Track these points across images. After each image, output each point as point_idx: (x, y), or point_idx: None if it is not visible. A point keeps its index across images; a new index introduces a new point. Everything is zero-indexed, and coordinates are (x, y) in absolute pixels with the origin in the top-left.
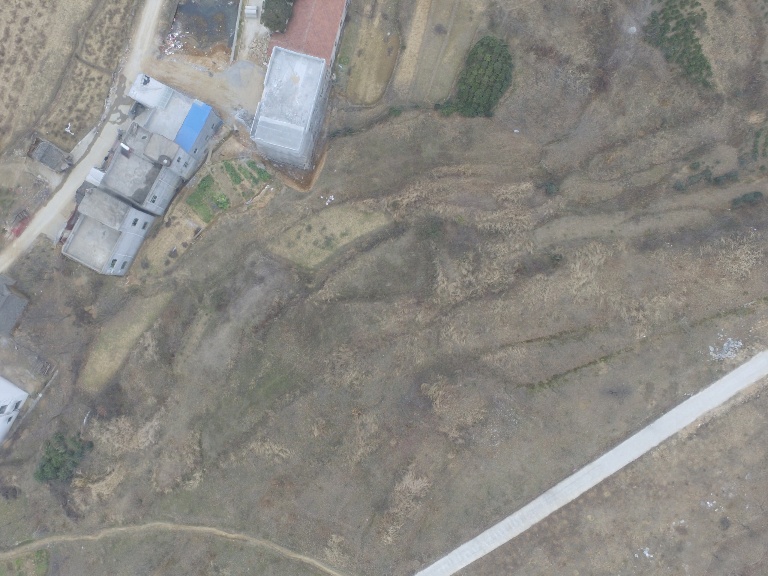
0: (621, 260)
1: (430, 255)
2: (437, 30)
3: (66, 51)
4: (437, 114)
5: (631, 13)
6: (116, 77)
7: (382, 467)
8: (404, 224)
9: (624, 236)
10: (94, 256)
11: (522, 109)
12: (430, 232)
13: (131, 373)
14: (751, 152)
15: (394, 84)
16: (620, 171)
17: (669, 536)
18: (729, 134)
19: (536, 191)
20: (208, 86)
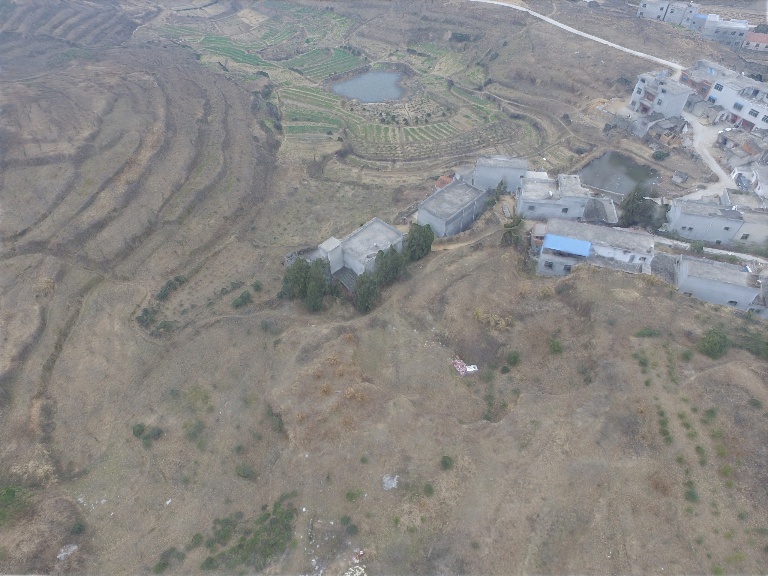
0: None
1: None
2: None
3: None
4: None
5: None
6: None
7: None
8: None
9: None
10: None
11: None
12: None
13: None
14: None
15: None
16: None
17: None
18: None
19: None
20: None
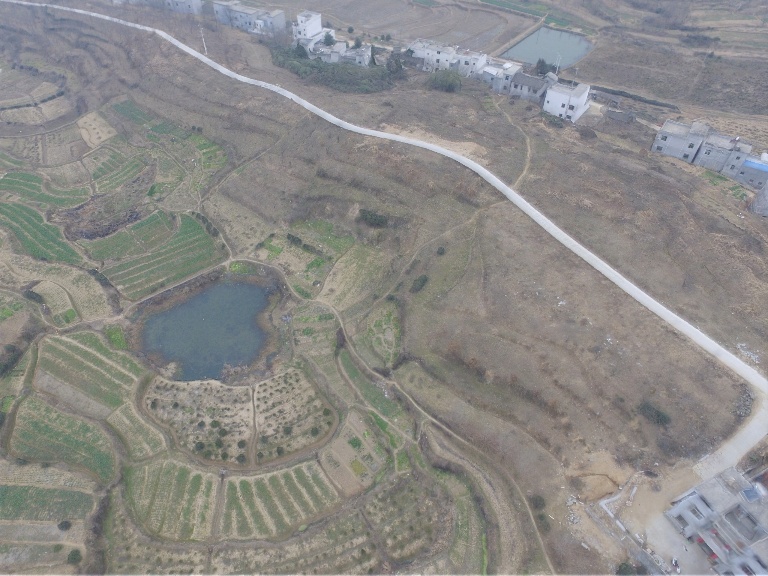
0: None
1: None
2: None
3: None
4: None
5: None
6: None
7: (590, 197)
8: (746, 233)
9: None
10: (668, 130)
11: None
12: None
13: (603, 142)
14: None
15: None
16: None
17: (577, 315)
18: None
19: None
20: None
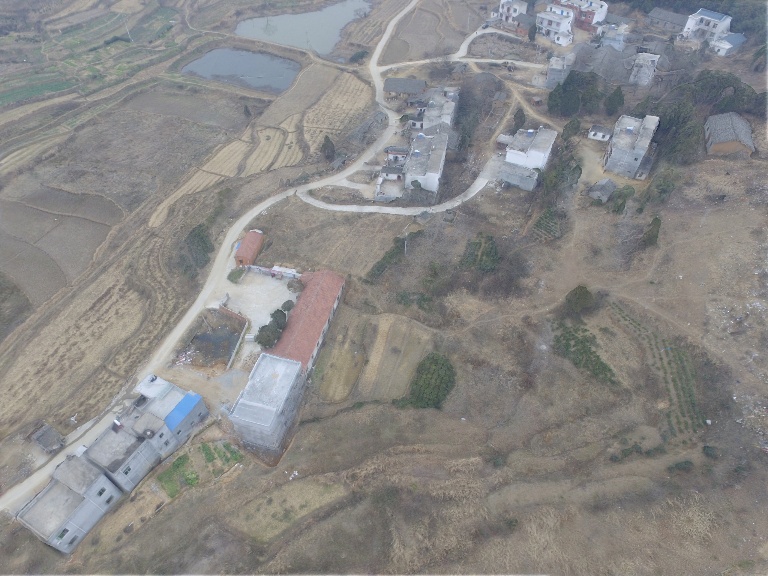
0: (577, 524)
1: (387, 523)
2: (393, 350)
3: (97, 363)
4: (394, 406)
5: (539, 337)
6: (130, 379)
7: None
8: (362, 494)
9: (575, 502)
10: (48, 523)
11: (466, 403)
12: (386, 500)
13: None
14: (669, 430)
15: (359, 386)
16: (560, 448)
17: None
18: (646, 418)
19: (485, 464)
20: (204, 386)
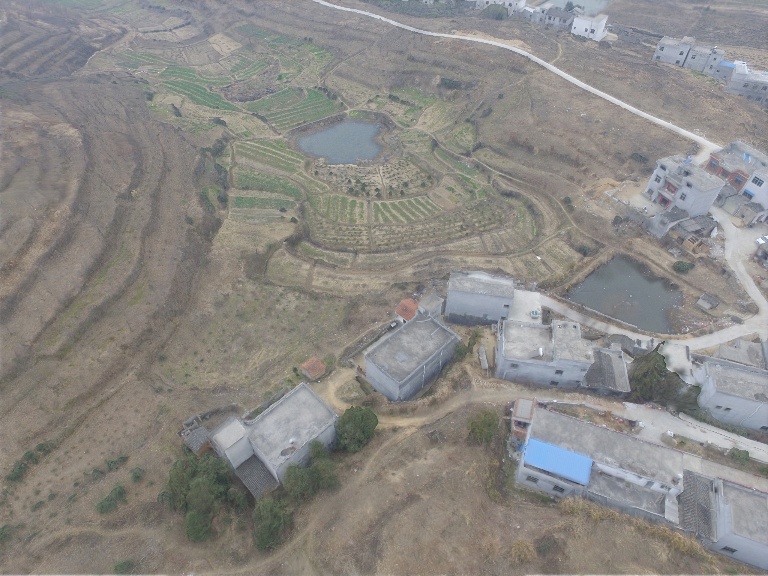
0: (730, 120)
1: None
2: None
3: None
4: None
5: None
6: None
7: None
8: None
9: None
10: None
11: None
12: None
13: None
14: None
15: None
16: None
17: None
18: None
19: None
20: None
